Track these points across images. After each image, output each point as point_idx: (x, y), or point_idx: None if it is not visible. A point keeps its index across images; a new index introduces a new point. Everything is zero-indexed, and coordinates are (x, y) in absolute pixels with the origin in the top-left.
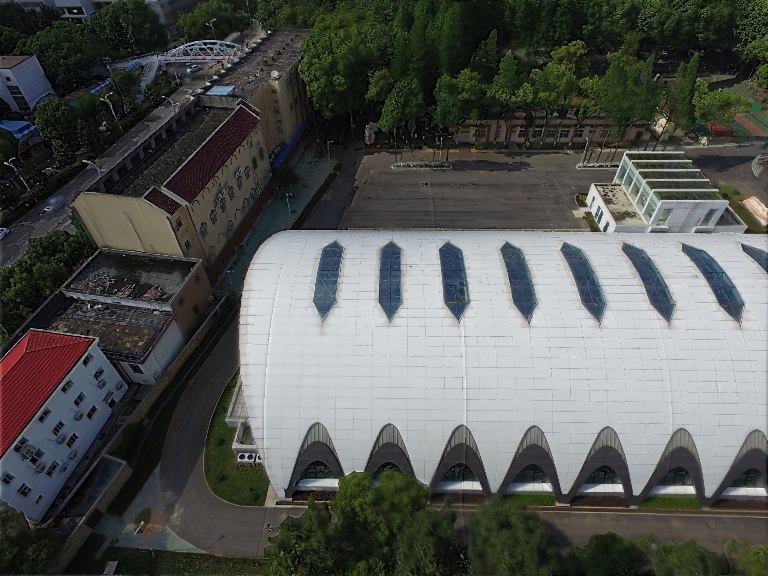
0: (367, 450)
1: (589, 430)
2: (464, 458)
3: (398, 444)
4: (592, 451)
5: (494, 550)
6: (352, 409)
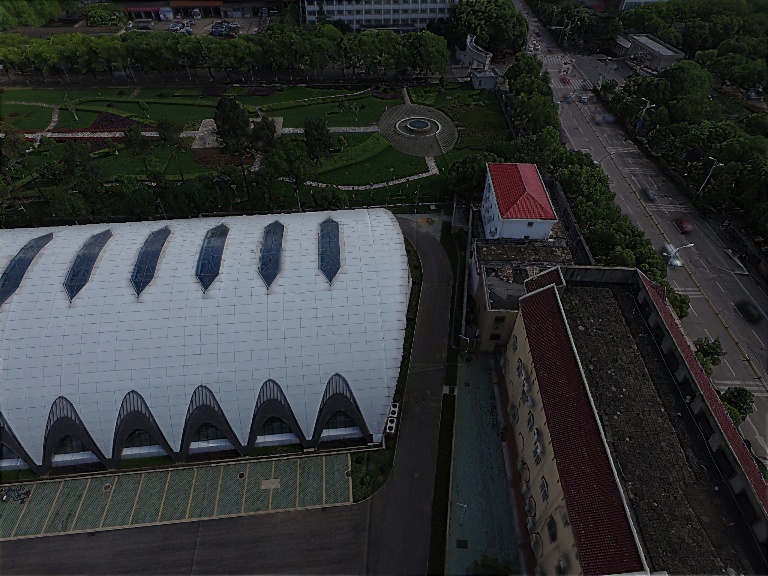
0: None
1: None
2: None
3: None
4: None
5: None
6: None
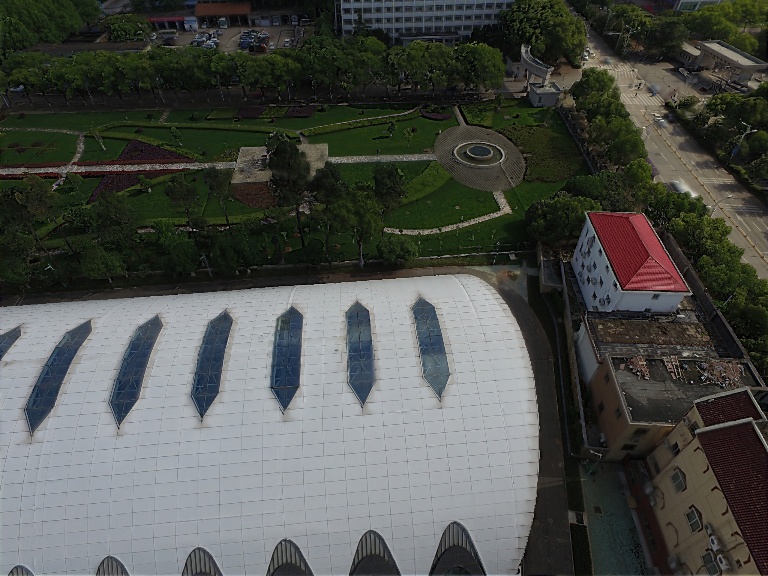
0: None
1: None
2: None
3: None
4: None
5: (300, 157)
6: None
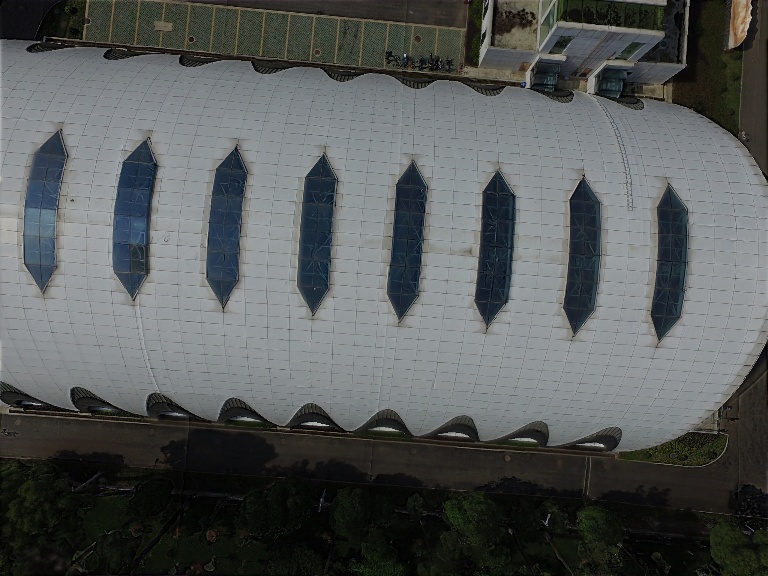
0: (66, 399)
1: (292, 404)
2: (170, 409)
3: (96, 398)
4: (298, 414)
5: None
6: (29, 374)
